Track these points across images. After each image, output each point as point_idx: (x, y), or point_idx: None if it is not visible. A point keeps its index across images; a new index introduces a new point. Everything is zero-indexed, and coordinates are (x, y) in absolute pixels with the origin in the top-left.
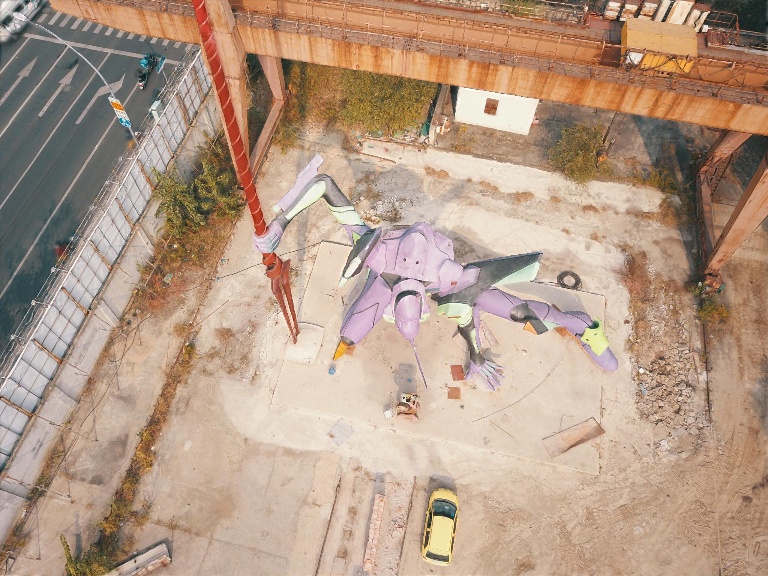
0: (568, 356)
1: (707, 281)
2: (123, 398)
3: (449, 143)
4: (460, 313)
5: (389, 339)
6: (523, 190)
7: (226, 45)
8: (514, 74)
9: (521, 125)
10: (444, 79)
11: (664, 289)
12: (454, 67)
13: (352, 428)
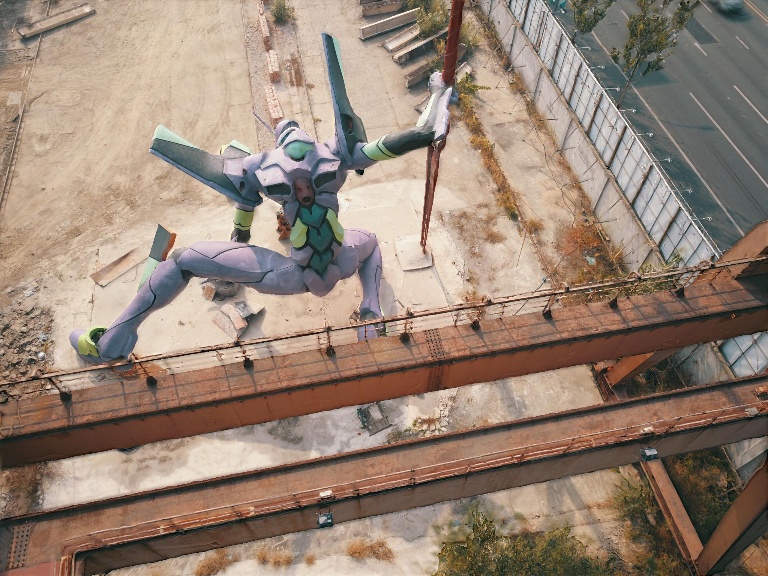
0: None
1: None
2: (531, 168)
3: None
4: None
5: None
6: None
7: None
8: None
9: None
10: None
11: None
12: None
13: None
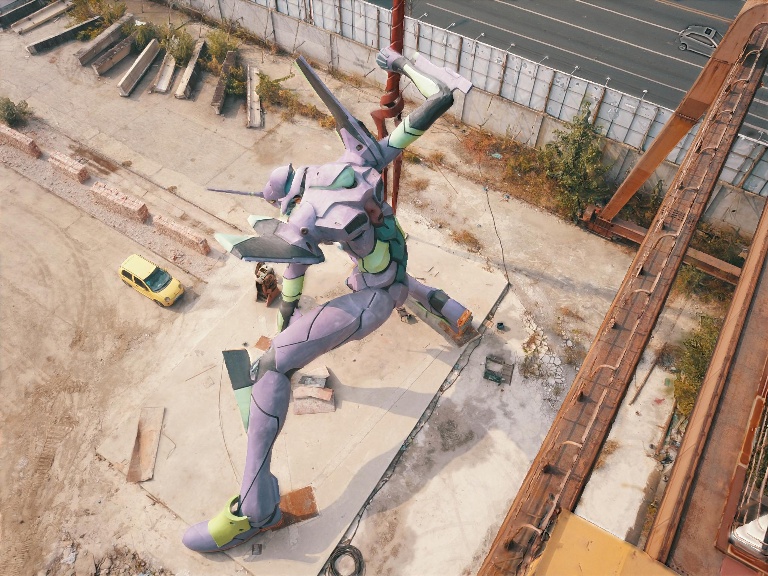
0: None
1: None
2: None
3: None
4: None
5: None
6: None
7: None
8: None
9: None
10: None
11: None
12: None
13: None
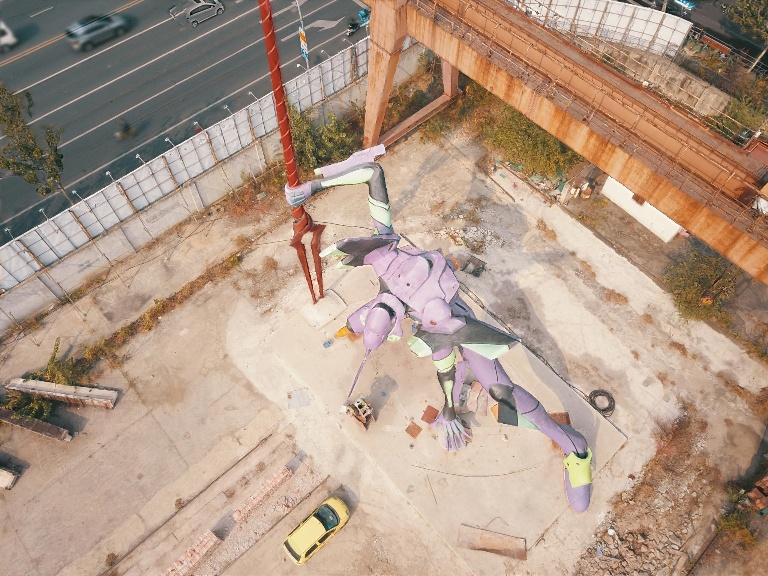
0: (545, 469)
1: (751, 493)
2: (167, 268)
3: (580, 210)
4: (419, 352)
5: (393, 349)
6: (621, 291)
7: (389, 19)
8: (629, 163)
9: (664, 229)
10: (563, 137)
11: (700, 472)
12: (575, 129)
13: (310, 401)
